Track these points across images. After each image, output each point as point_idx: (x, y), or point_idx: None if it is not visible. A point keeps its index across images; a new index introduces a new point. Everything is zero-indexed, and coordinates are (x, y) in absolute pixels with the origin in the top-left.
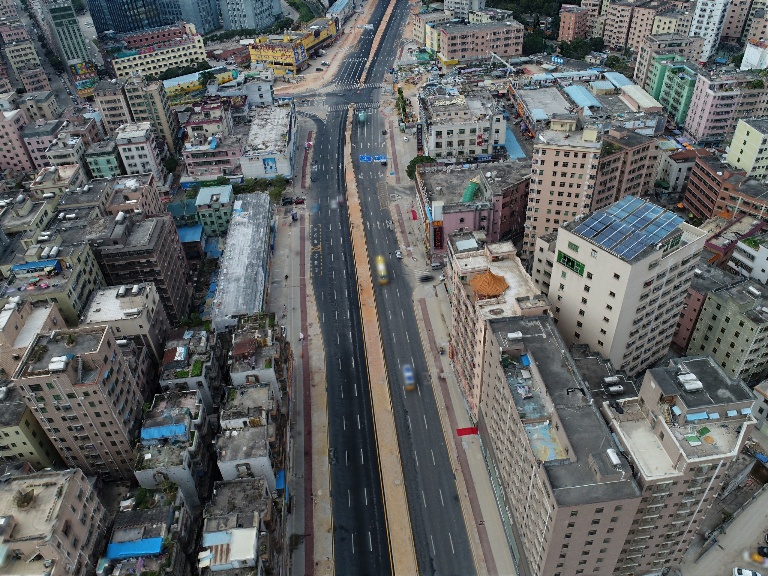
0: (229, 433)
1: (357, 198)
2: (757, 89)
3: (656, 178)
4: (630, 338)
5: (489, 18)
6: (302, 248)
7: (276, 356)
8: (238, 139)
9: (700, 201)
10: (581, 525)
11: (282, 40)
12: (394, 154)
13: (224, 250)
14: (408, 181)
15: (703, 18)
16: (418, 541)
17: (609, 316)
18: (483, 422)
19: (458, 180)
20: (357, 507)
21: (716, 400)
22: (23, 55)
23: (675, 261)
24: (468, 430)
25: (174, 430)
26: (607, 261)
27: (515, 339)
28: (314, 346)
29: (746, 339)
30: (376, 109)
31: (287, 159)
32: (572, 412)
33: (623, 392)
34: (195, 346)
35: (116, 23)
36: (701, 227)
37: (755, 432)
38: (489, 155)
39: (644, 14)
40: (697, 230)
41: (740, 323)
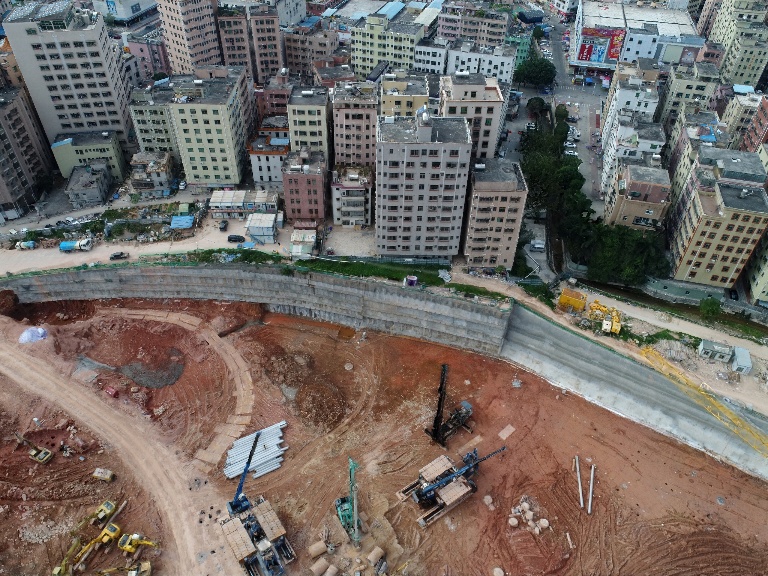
0: None
1: None
2: (476, 17)
3: None
4: (51, 92)
5: None
6: None
7: None
8: None
9: None
10: None
11: None
12: None
13: (3, 39)
14: None
15: None
16: None
17: None
18: None
19: None
20: None
21: None
22: None
23: (63, 40)
24: None
25: None
26: None
27: None
28: None
29: None
30: None
31: (124, 5)
32: None
33: None
34: None
35: None
36: None
37: None
38: None
39: None
40: None
41: None
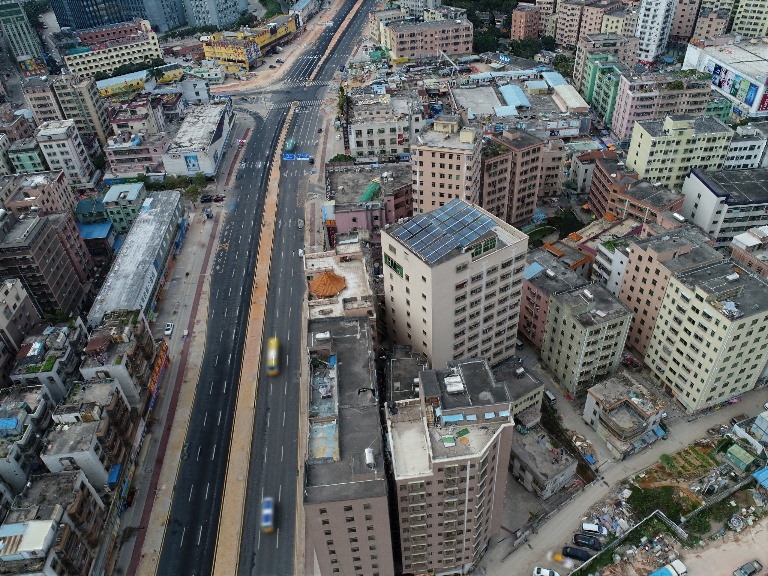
0: (60, 427)
1: (276, 196)
2: (676, 90)
3: (568, 179)
4: (456, 339)
5: (442, 16)
6: (210, 245)
7: (129, 353)
8: (161, 137)
9: (600, 203)
10: (336, 522)
11: (236, 37)
12: (324, 152)
13: (121, 247)
14: None
15: (648, 17)
16: (246, 536)
17: (425, 318)
18: None
19: (365, 179)
20: (196, 501)
21: (475, 402)
22: None
23: (492, 264)
24: None
25: (5, 424)
26: (415, 264)
27: (323, 339)
28: (196, 343)
29: (578, 342)
30: (318, 107)
31: (209, 157)
32: (355, 412)
33: None
34: (51, 342)
35: (77, 19)
36: (586, 229)
37: (591, 434)
38: None
39: (593, 13)
40: (520, 233)
41: (573, 326)
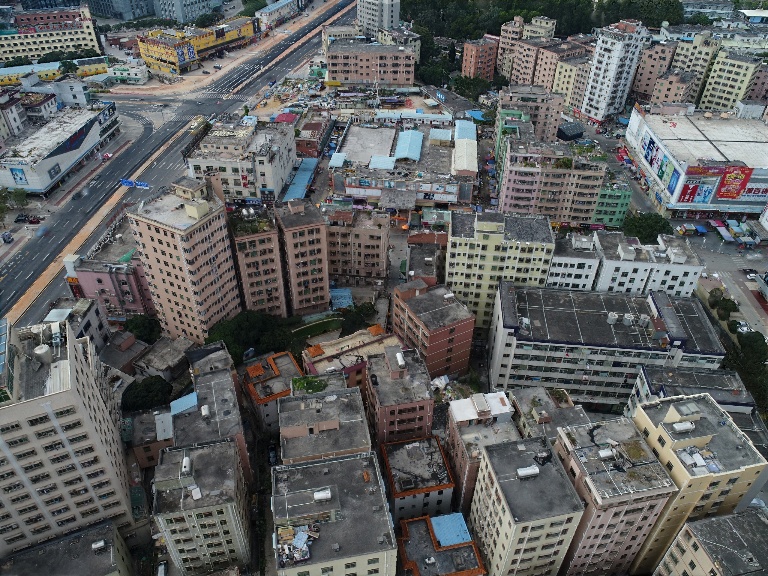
0: None
1: (94, 227)
2: (562, 169)
3: (406, 258)
4: None
5: (392, 40)
6: None
7: None
8: None
9: None
10: None
11: (175, 36)
12: None
13: None
14: None
15: (599, 71)
16: None
17: None
18: None
19: None
20: None
21: None
22: None
23: (5, 421)
24: None
25: None
26: None
27: None
28: None
29: None
30: None
31: (38, 172)
32: None
33: None
34: None
35: None
36: (345, 339)
37: None
38: (258, 199)
39: (548, 57)
40: None
41: None
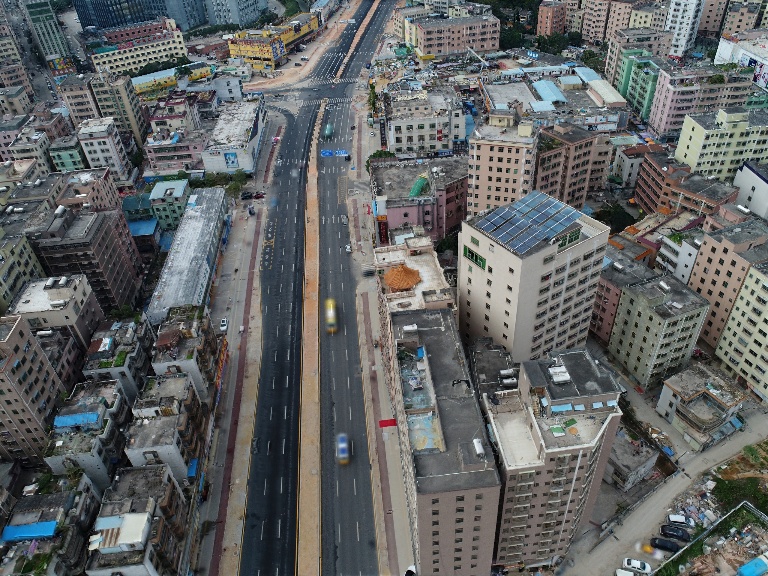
0: (140, 422)
1: (316, 193)
2: (717, 84)
3: (611, 173)
4: (535, 332)
5: (467, 13)
6: (255, 242)
7: (199, 347)
8: (200, 134)
9: (648, 196)
10: (446, 513)
11: (261, 35)
12: (359, 149)
13: (172, 243)
14: (369, 176)
15: (678, 12)
16: (325, 529)
17: (509, 310)
18: (396, 413)
19: (410, 175)
20: (271, 495)
21: (582, 392)
22: (3, 50)
23: (575, 256)
24: (390, 422)
25: (86, 418)
26: (502, 255)
27: (410, 332)
28: (253, 338)
29: (655, 334)
30: (348, 104)
31: (248, 154)
32: (453, 403)
33: (517, 384)
34: (121, 337)
35: (100, 18)
36: (641, 222)
37: (666, 426)
38: (450, 150)
39: (621, 8)
40: (601, 225)
41: (650, 318)
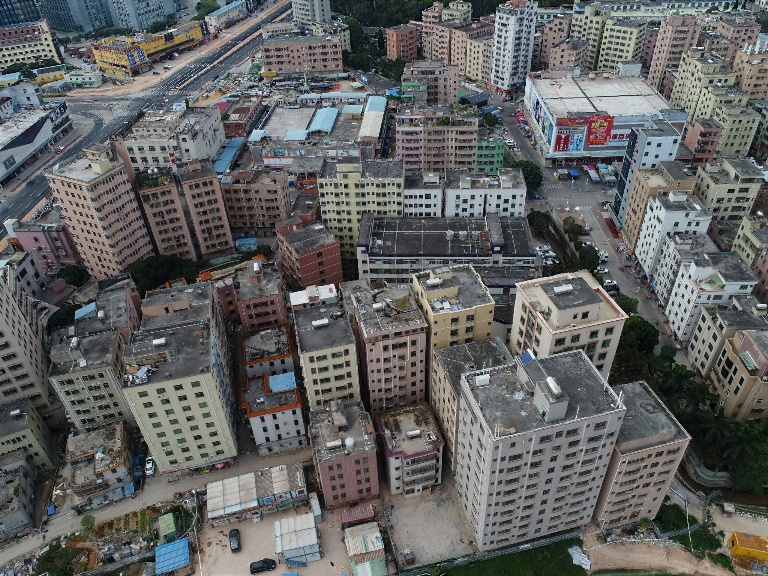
0: None
1: None
2: (441, 126)
3: None
4: None
5: (323, 31)
6: None
7: None
8: None
9: None
10: None
11: (126, 42)
12: None
13: None
14: None
15: (500, 44)
16: None
17: None
18: None
19: None
20: None
21: None
22: None
23: None
24: None
25: None
26: None
27: None
28: None
29: None
30: None
31: None
32: None
33: None
34: None
35: None
36: (234, 268)
37: None
38: None
39: (459, 36)
40: None
41: None
